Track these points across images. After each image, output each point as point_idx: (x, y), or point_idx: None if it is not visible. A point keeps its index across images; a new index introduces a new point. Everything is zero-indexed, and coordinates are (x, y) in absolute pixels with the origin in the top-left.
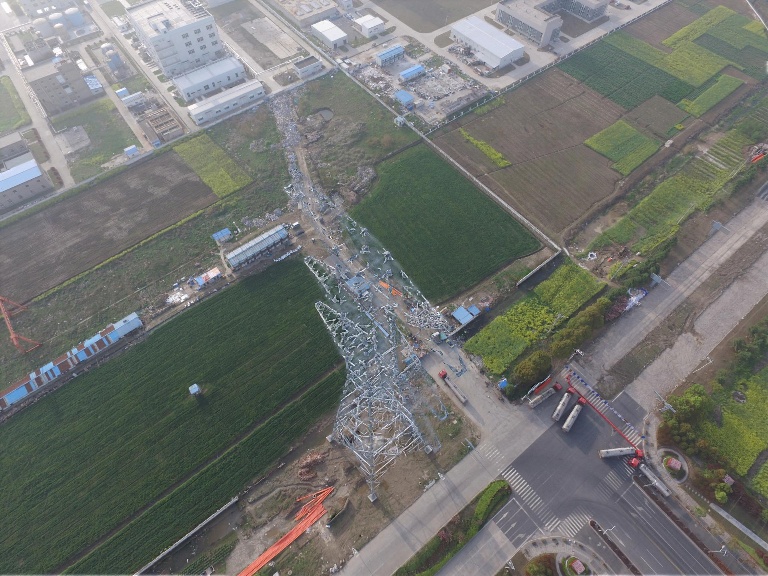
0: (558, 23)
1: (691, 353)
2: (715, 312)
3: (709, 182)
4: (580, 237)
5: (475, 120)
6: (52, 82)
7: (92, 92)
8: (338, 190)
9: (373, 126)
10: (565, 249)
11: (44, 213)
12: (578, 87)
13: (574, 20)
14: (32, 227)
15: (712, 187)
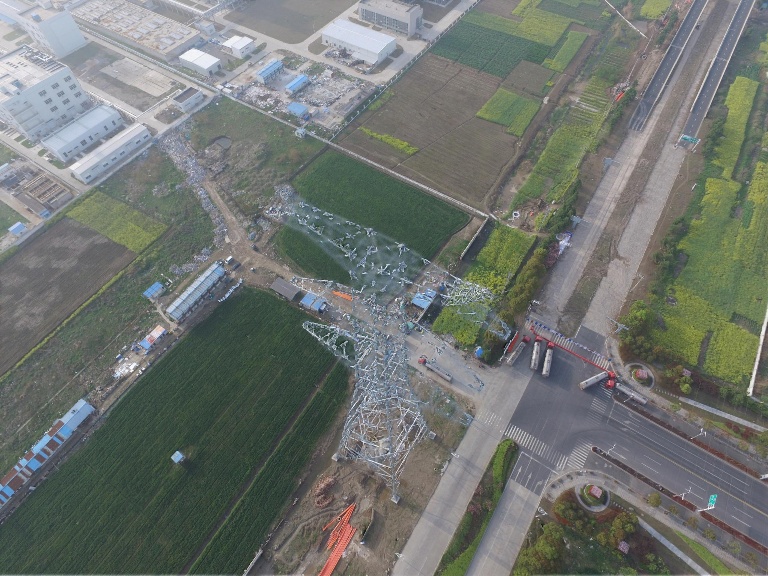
0: (419, 12)
1: (623, 276)
2: (630, 235)
3: (589, 126)
4: (500, 200)
5: (372, 116)
6: None
7: None
8: (261, 214)
9: (276, 143)
10: (491, 215)
11: None
12: (454, 66)
13: (431, 7)
14: None
15: (593, 130)
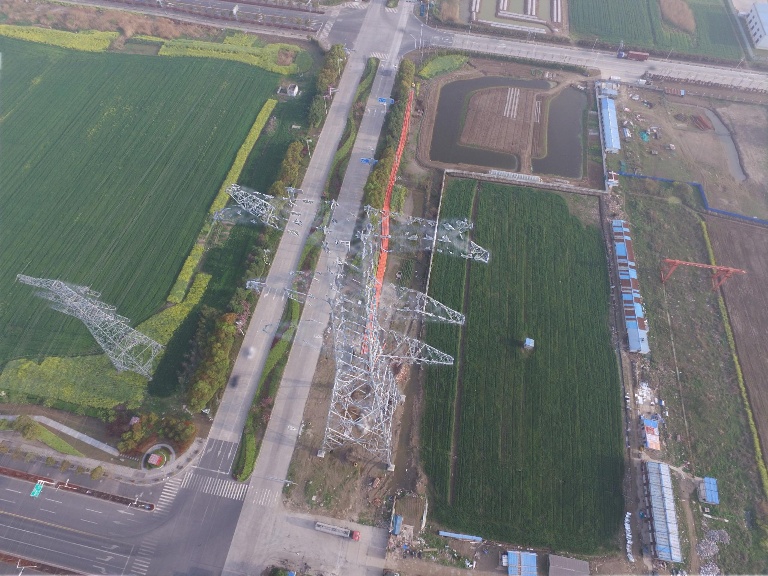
0: None
1: None
2: None
3: None
4: None
5: None
6: None
7: None
8: None
9: None
10: None
11: None
12: None
13: None
14: None
15: None
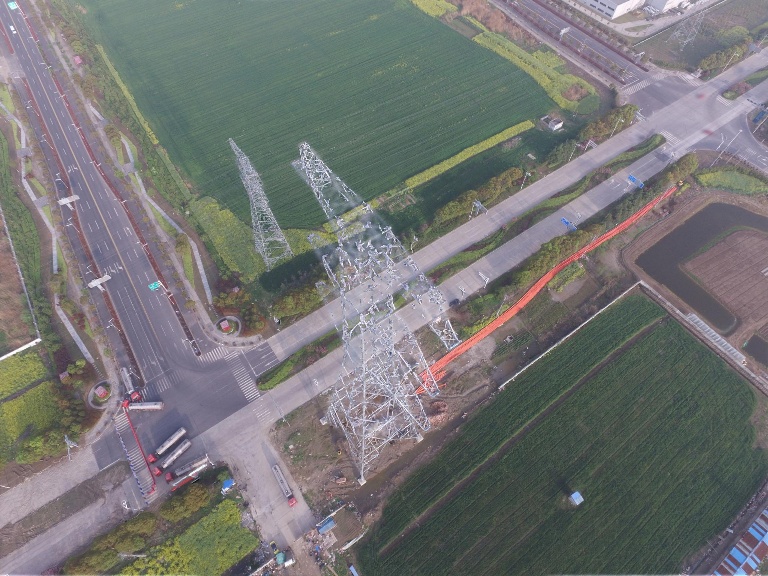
0: None
1: None
2: None
3: None
4: None
5: None
6: None
7: None
8: None
9: None
10: None
11: None
12: None
13: None
14: None
15: None
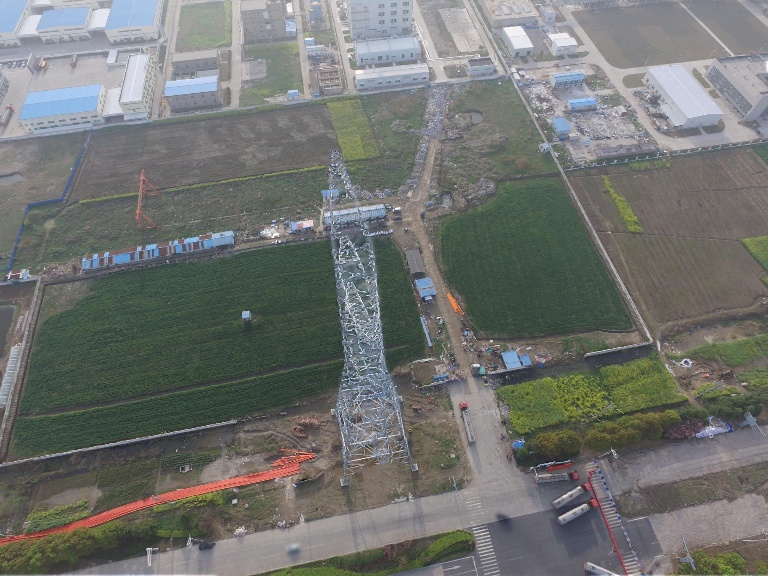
0: None
1: (752, 519)
2: None
3: None
4: (683, 338)
5: (626, 173)
6: (258, 16)
7: (287, 34)
8: (452, 192)
9: (516, 144)
10: (658, 343)
11: (206, 123)
12: (767, 178)
13: None
14: (192, 131)
15: None
